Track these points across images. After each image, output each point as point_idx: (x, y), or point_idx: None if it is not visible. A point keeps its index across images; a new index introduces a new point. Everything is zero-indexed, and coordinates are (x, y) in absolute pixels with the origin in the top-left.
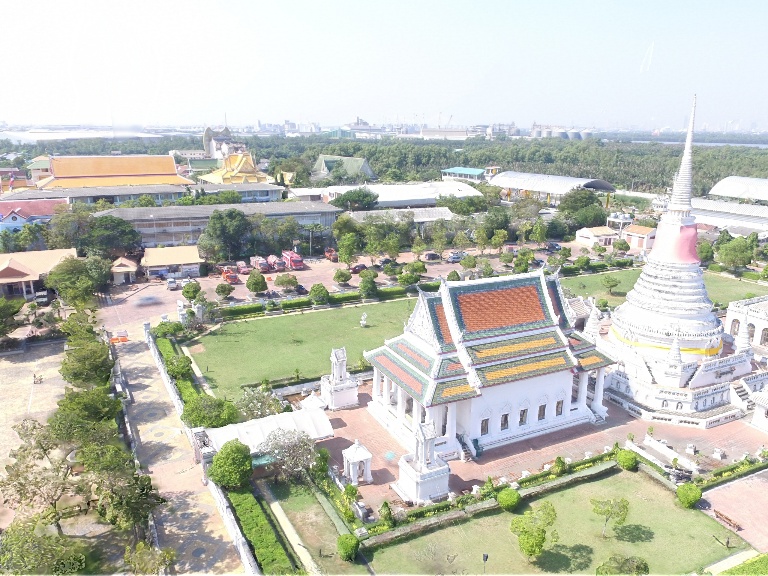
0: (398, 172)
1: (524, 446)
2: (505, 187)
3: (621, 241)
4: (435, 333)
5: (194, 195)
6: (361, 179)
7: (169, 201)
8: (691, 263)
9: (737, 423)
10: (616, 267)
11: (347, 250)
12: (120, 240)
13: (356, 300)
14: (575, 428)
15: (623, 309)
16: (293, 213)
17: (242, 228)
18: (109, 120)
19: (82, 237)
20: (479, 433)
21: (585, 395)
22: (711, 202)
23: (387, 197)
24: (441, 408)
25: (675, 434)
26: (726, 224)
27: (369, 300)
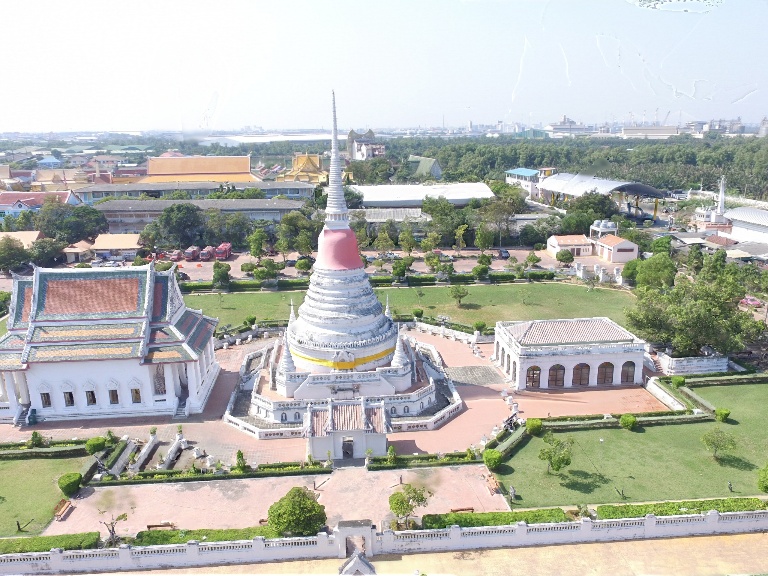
0: (452, 173)
1: (80, 424)
2: (548, 190)
3: (563, 251)
4: (15, 312)
5: (226, 191)
6: (423, 179)
7: (200, 196)
8: (334, 270)
9: (301, 440)
10: (525, 279)
11: (255, 244)
12: (86, 226)
13: (207, 289)
14: (151, 418)
15: None
16: (253, 209)
17: (184, 220)
18: (180, 126)
19: (56, 222)
20: (40, 405)
21: (170, 388)
22: (753, 212)
23: (383, 197)
24: (22, 378)
25: (222, 438)
26: (764, 240)
27: (218, 290)
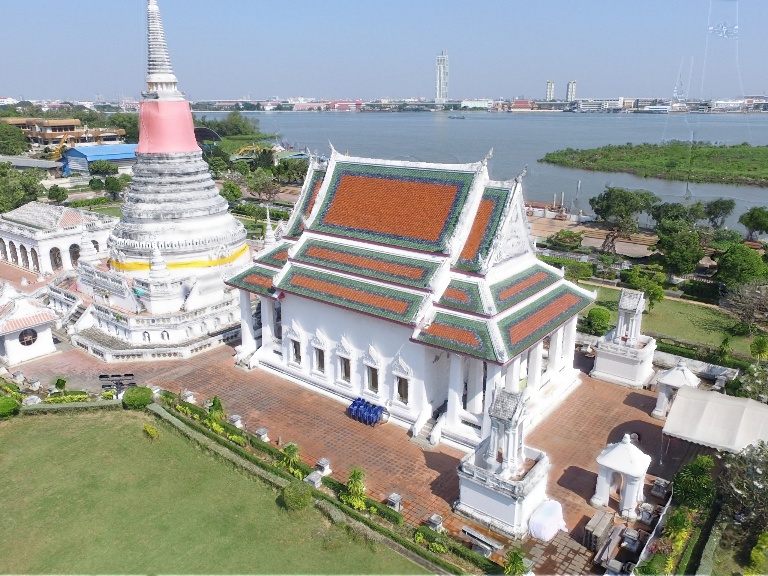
0: None
1: None
2: None
3: None
4: None
5: None
6: None
7: None
8: None
9: None
10: None
11: None
12: None
13: None
14: None
15: (178, 231)
16: None
17: None
18: None
19: None
20: None
21: None
22: None
23: None
24: None
25: None
26: None
27: None
